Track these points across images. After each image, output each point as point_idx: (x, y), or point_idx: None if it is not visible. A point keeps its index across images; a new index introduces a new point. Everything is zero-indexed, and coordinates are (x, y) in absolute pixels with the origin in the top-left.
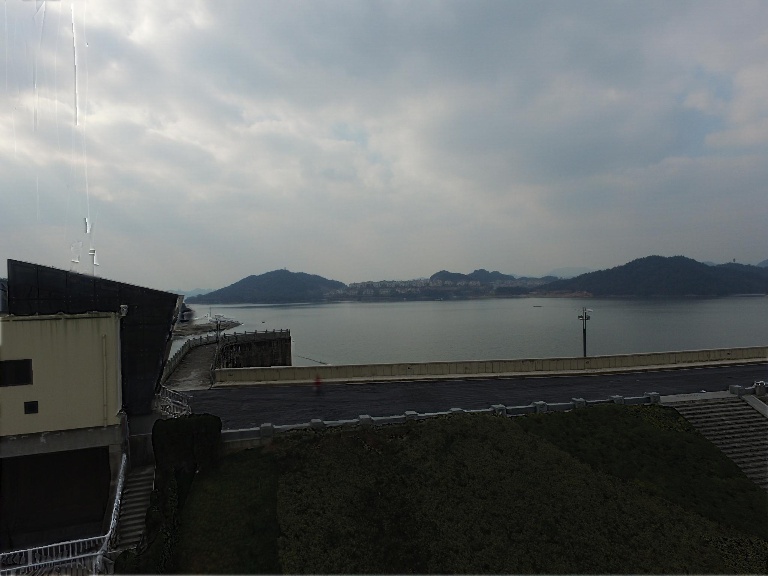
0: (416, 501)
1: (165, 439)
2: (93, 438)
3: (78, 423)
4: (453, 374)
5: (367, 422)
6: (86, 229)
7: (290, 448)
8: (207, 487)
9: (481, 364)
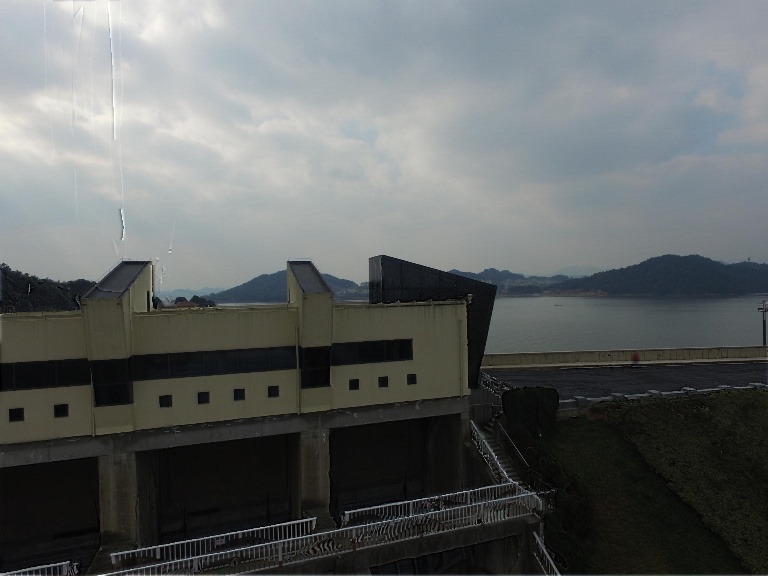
0: (757, 457)
1: (519, 407)
2: (450, 406)
3: (442, 393)
4: (649, 360)
5: (659, 396)
6: (122, 228)
7: (619, 415)
8: (562, 447)
9: (673, 352)
